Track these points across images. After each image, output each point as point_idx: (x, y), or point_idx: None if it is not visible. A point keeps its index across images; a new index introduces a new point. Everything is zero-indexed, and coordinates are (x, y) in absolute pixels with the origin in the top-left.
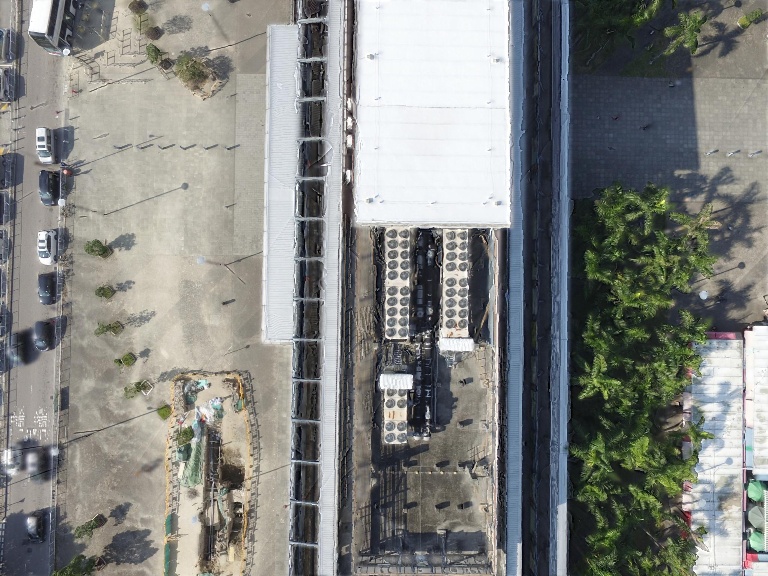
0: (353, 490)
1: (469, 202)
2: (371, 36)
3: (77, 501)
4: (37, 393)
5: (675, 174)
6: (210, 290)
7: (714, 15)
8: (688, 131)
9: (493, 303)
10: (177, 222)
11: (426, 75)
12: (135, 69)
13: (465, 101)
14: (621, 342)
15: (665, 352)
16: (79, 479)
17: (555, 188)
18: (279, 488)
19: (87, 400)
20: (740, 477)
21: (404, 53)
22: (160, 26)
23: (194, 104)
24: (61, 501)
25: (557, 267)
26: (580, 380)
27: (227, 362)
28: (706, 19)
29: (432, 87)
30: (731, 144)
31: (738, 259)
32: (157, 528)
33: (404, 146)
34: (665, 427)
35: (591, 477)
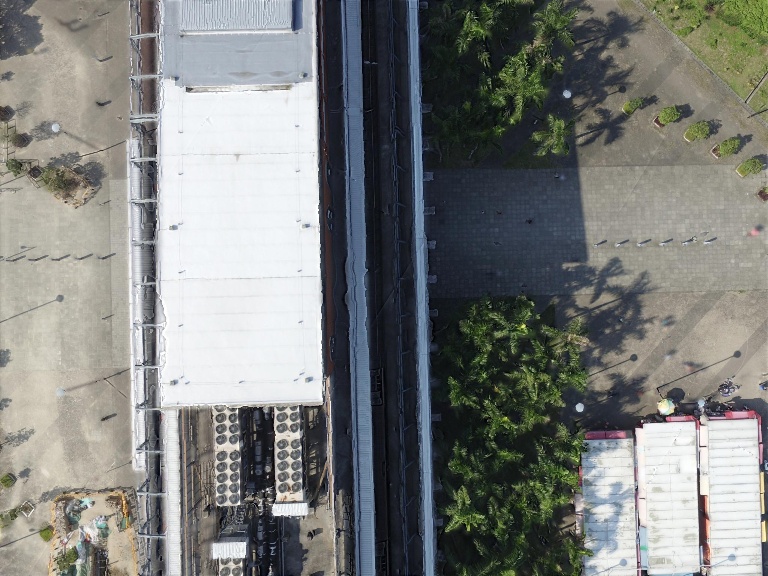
0: None
1: (278, 380)
2: (174, 205)
3: None
4: None
5: (563, 267)
6: (90, 405)
7: (598, 102)
8: (575, 222)
9: (328, 463)
10: (53, 336)
11: (232, 245)
12: (4, 178)
13: (274, 271)
14: (492, 465)
15: (542, 468)
16: None
17: (416, 313)
18: None
19: None
20: None
21: (209, 222)
22: (28, 132)
23: (66, 213)
24: None
25: (419, 396)
26: (447, 511)
27: (110, 479)
28: (574, 123)
29: (239, 257)
30: (619, 234)
31: (630, 351)
32: None
33: (210, 322)
34: (561, 526)
35: None
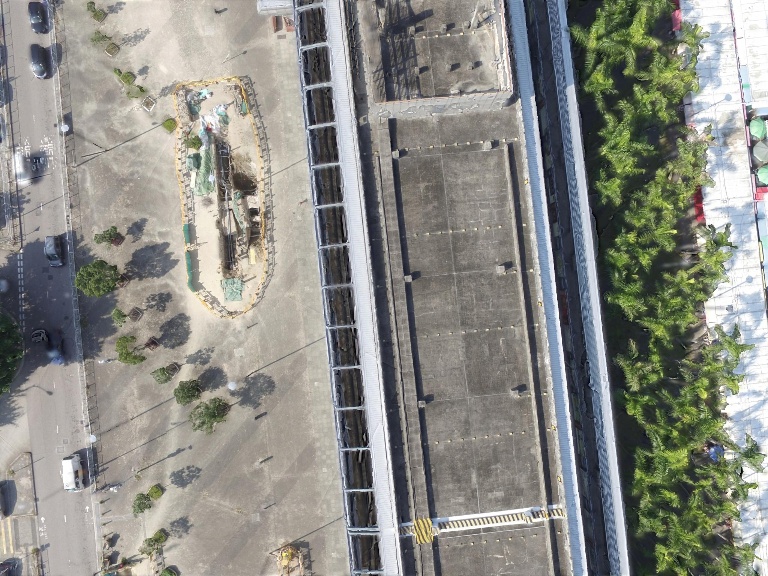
0: (364, 61)
1: None
2: None
3: (92, 223)
4: (40, 122)
5: None
6: (201, 2)
7: None
8: None
9: None
10: None
11: None
12: None
13: None
14: None
15: None
16: (92, 201)
17: None
18: (292, 186)
19: (91, 123)
20: (741, 112)
21: None
22: None
23: None
24: (76, 225)
25: None
26: None
27: (226, 70)
28: None
29: None
30: None
31: None
32: (175, 240)
33: None
34: None
35: (595, 71)
